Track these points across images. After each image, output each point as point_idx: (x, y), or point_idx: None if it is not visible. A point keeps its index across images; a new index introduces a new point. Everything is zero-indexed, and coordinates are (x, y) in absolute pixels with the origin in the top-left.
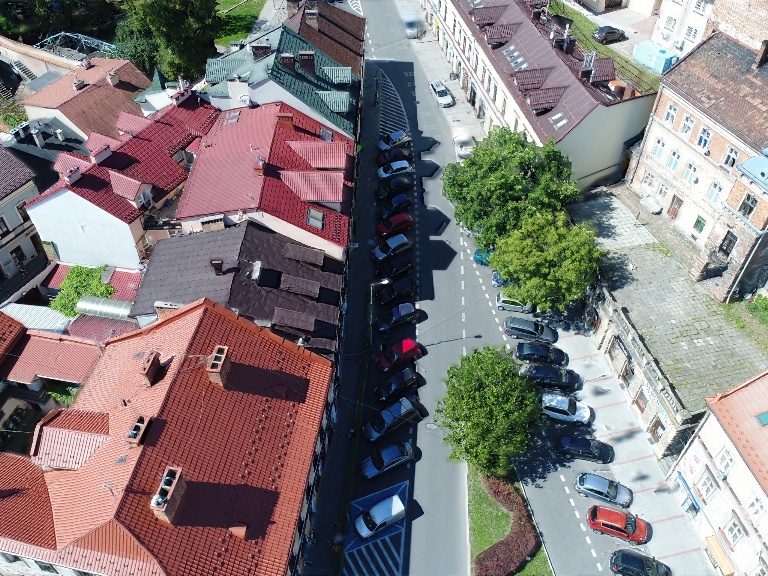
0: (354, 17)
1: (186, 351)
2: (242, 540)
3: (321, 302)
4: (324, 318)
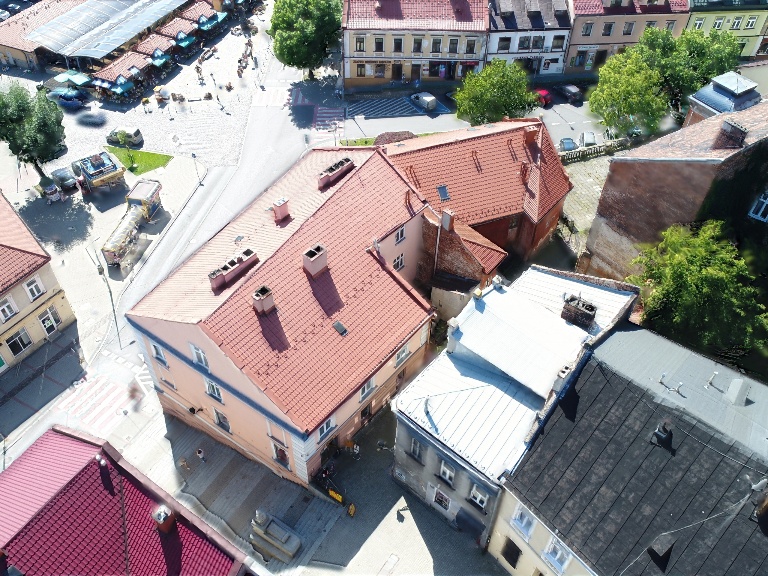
0: None
1: None
2: (375, 8)
3: (530, 18)
4: (519, 22)
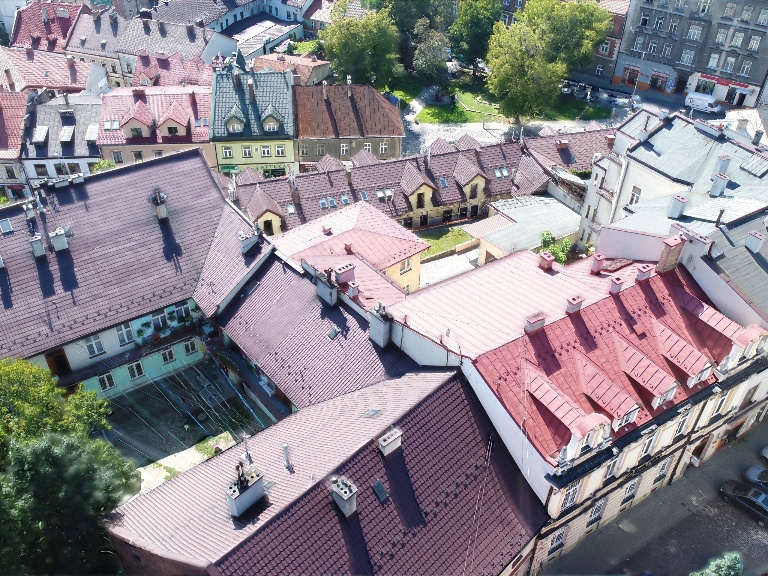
0: (393, 125)
1: (0, 92)
2: None
3: (63, 147)
4: (52, 150)
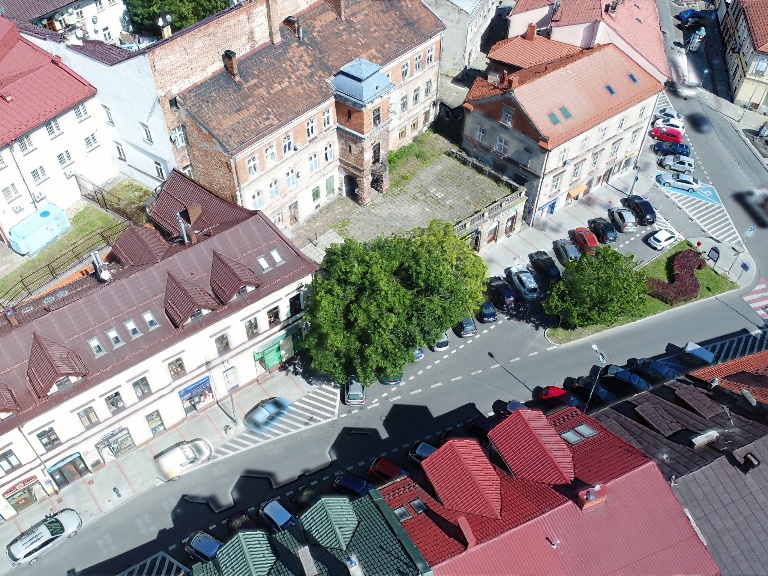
0: None
1: None
2: None
3: None
4: None
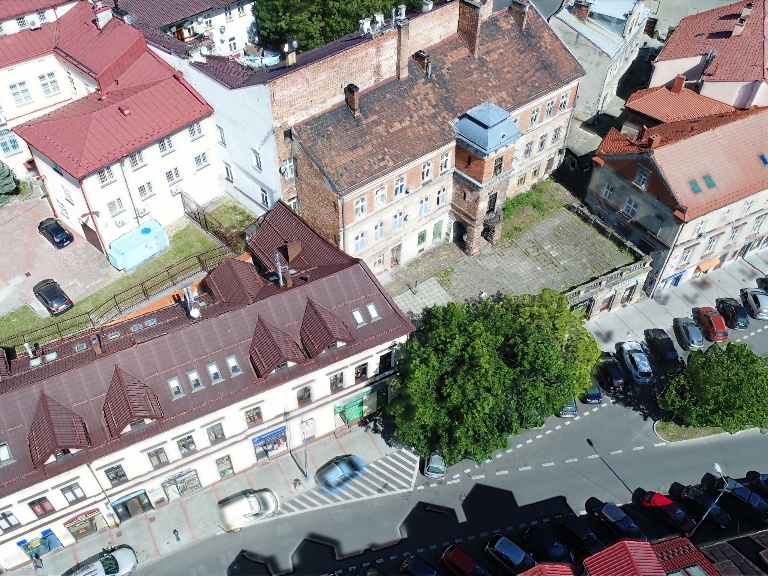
0: None
1: None
2: None
3: None
4: None
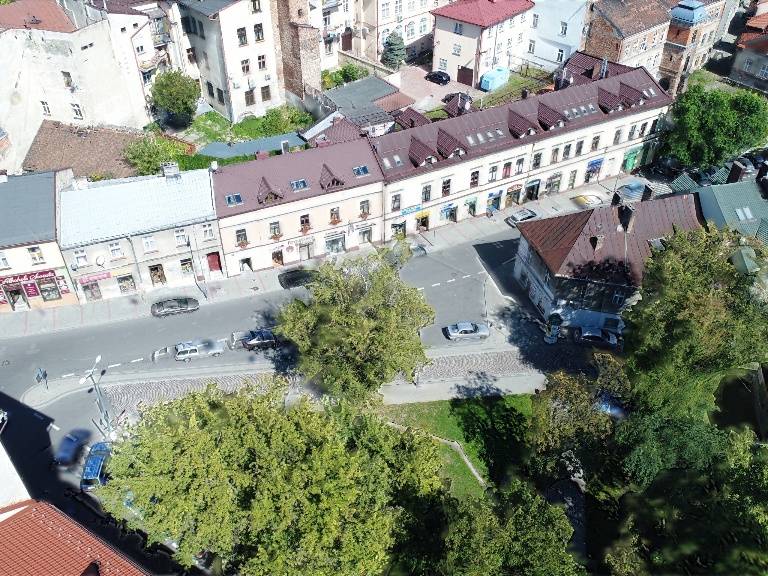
0: None
1: None
2: None
3: None
4: None
